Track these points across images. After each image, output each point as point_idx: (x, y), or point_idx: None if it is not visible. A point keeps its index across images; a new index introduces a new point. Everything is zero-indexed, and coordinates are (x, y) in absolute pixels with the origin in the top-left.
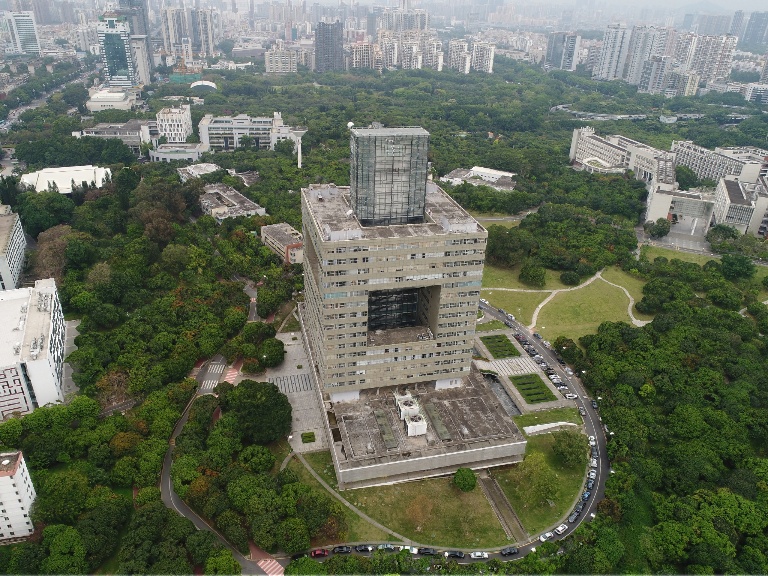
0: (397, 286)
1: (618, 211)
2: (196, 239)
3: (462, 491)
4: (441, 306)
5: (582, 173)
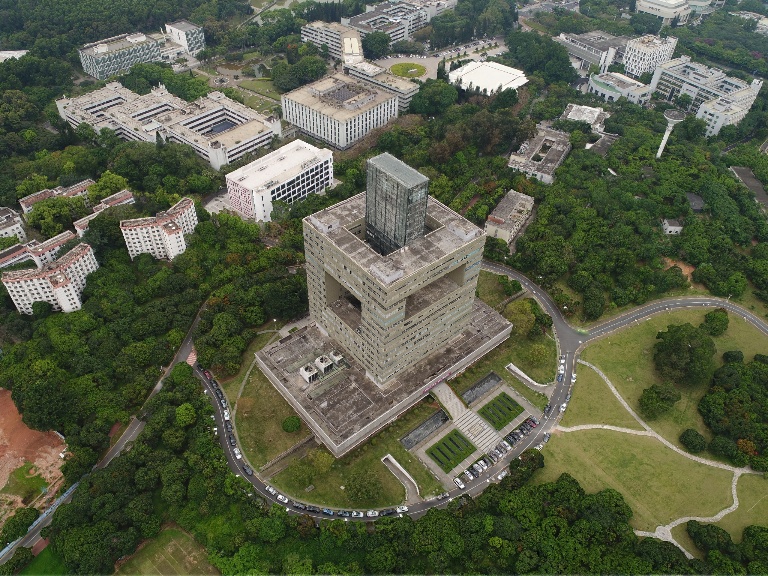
0: (338, 280)
1: None
2: (458, 172)
3: None
4: (363, 318)
5: None
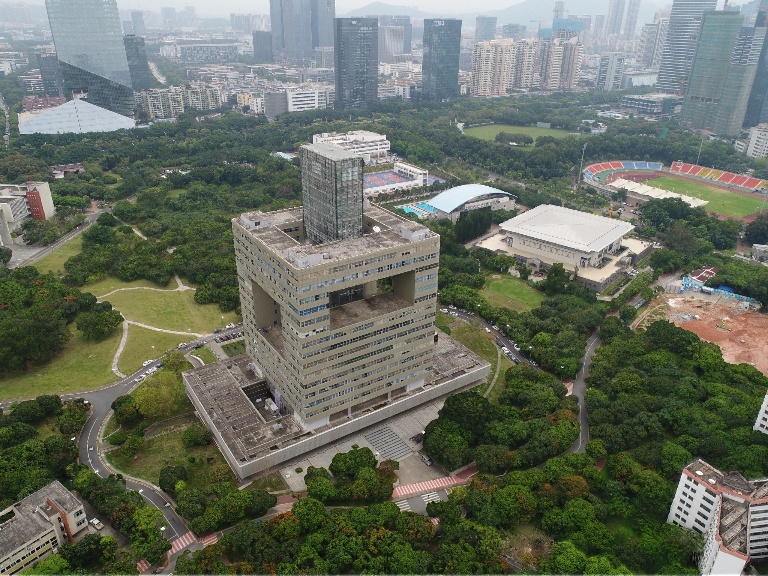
0: None
1: None
2: None
3: None
4: None
5: None
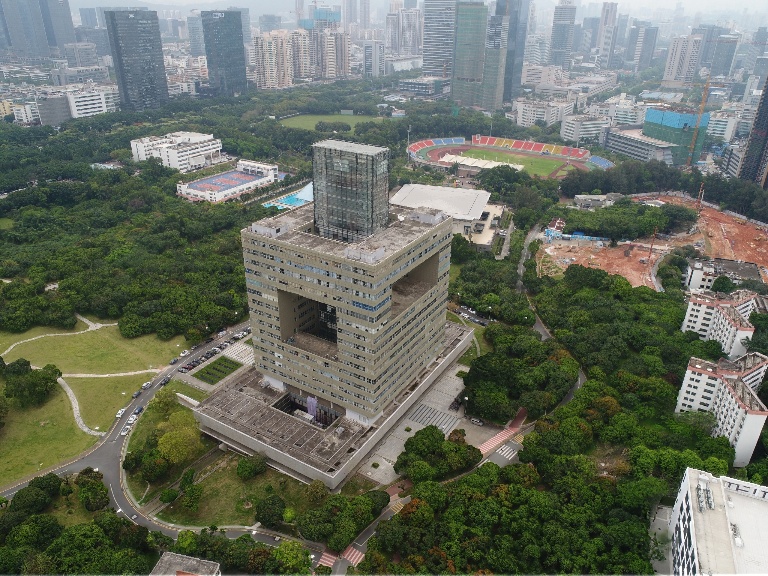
0: None
1: None
2: None
3: None
4: None
5: None
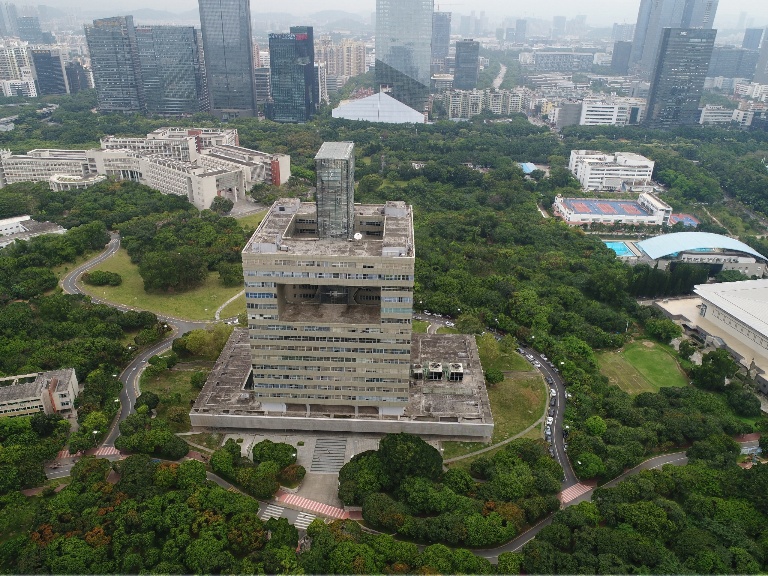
0: None
1: (173, 207)
2: None
3: (496, 385)
4: None
5: (81, 191)
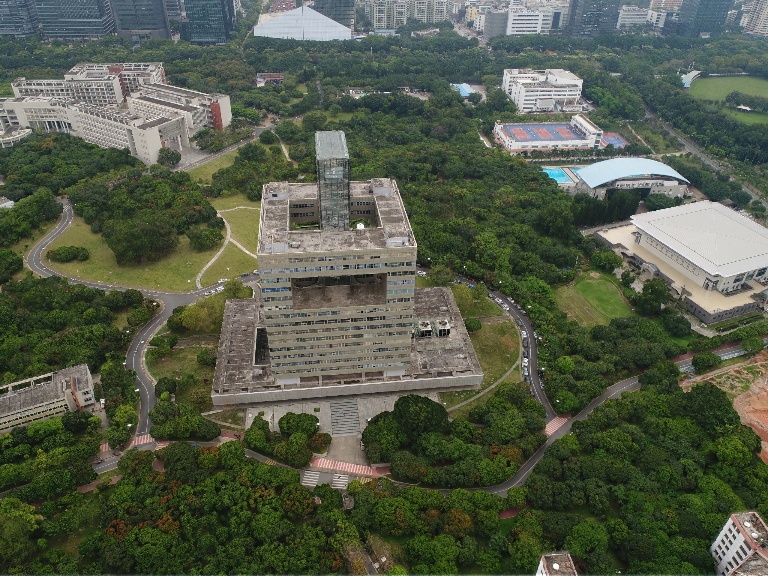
0: None
1: (117, 163)
2: None
3: None
4: None
5: (10, 150)
